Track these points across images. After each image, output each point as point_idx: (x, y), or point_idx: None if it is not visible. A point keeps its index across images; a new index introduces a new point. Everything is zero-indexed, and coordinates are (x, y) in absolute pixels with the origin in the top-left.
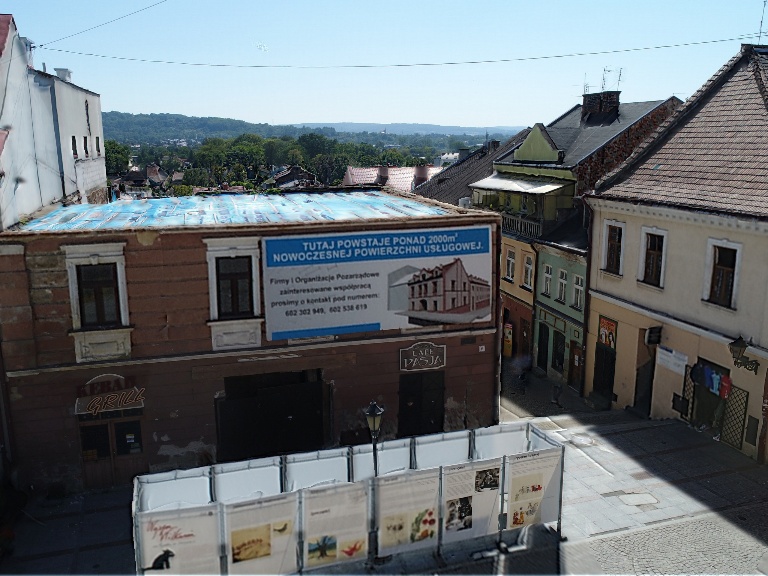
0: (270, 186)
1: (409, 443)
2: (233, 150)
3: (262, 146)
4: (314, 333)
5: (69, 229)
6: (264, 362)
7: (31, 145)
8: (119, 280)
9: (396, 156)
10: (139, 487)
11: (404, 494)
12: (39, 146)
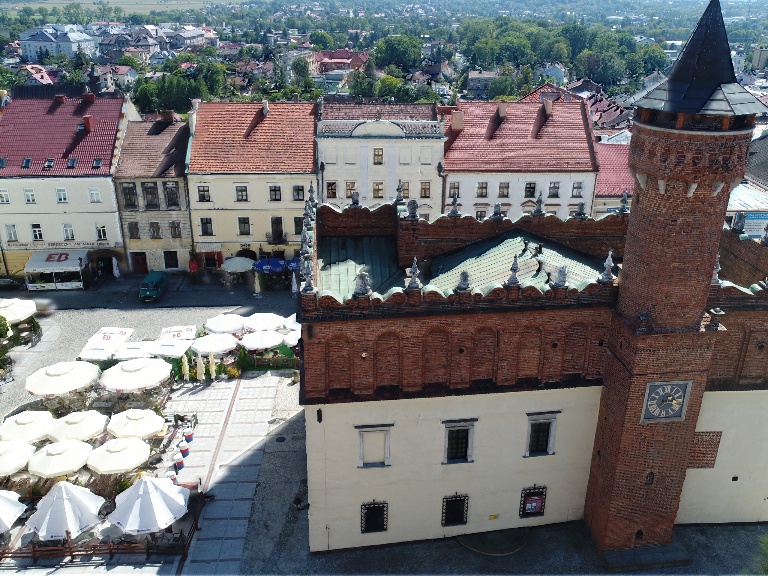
0: None
1: None
2: (504, 42)
3: (529, 38)
4: None
5: None
6: None
7: None
8: None
9: (658, 52)
10: None
11: None
12: None
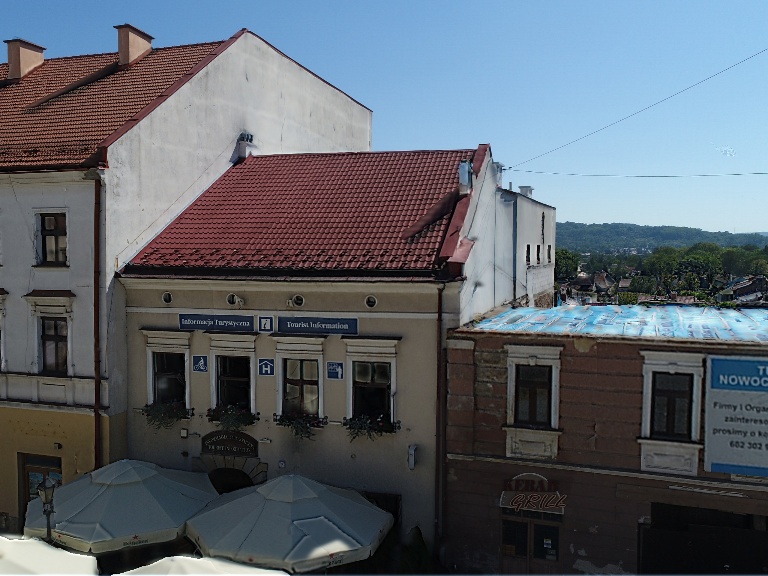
0: (726, 297)
1: None
2: (686, 258)
3: (720, 254)
4: (765, 472)
5: (514, 330)
6: (699, 494)
7: (492, 253)
8: (553, 383)
9: None
10: None
11: None
12: (498, 254)
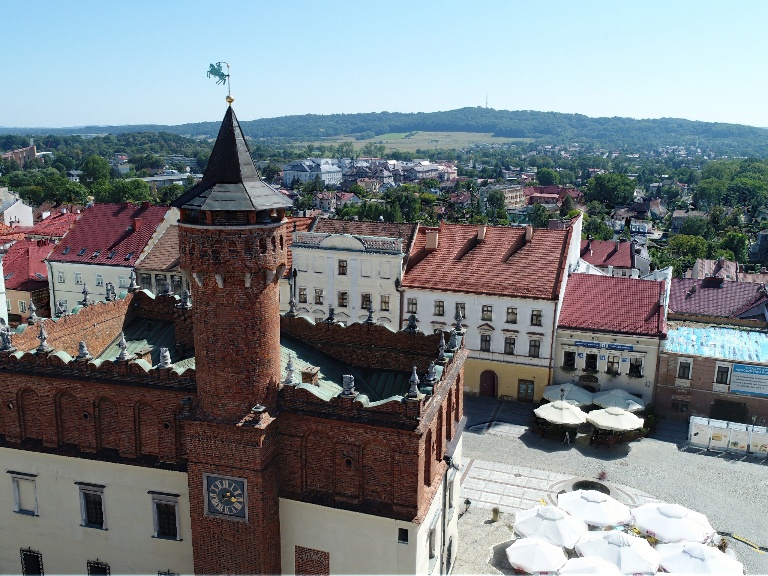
0: (765, 236)
1: (766, 428)
2: (735, 183)
3: (767, 180)
4: (745, 392)
5: None
6: (728, 397)
7: None
8: (691, 367)
9: None
10: (692, 418)
11: (759, 438)
12: None
